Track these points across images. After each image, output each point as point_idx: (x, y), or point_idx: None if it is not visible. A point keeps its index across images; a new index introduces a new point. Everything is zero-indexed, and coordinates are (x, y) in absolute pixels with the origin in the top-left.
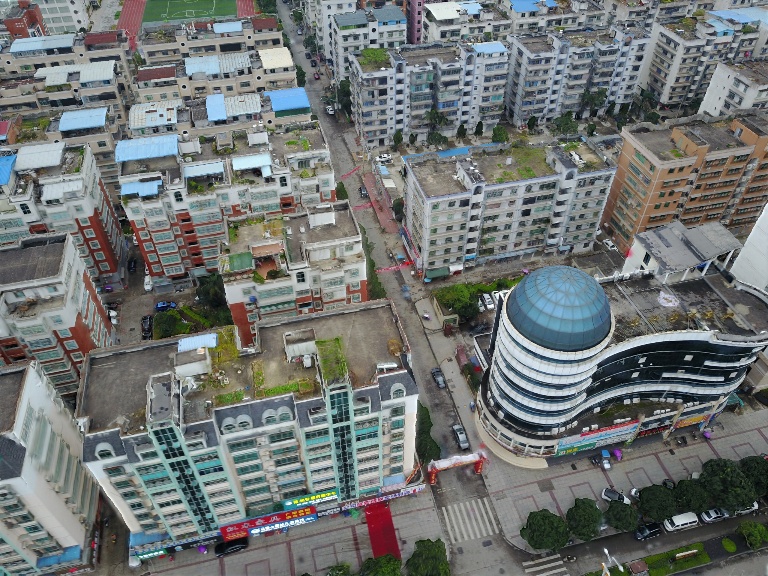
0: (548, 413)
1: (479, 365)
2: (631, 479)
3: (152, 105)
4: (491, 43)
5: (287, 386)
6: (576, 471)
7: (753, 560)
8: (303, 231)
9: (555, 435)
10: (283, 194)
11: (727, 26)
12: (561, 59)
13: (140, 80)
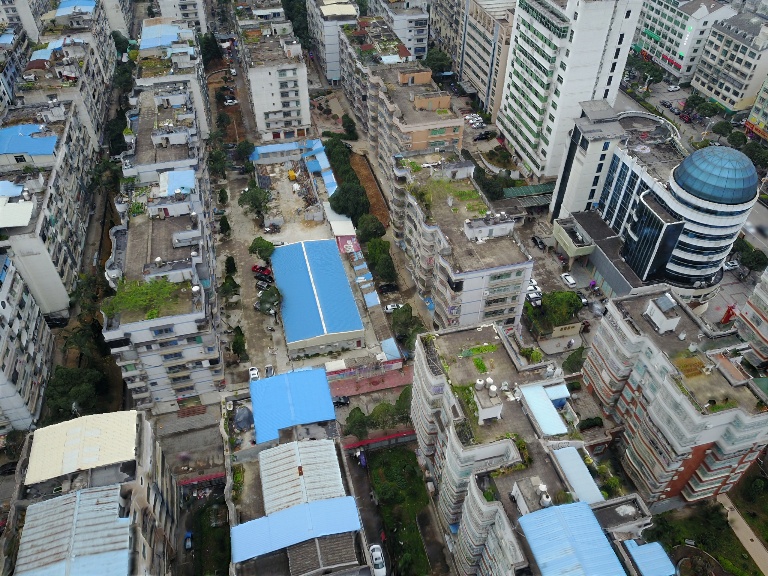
0: None
1: None
2: None
3: None
4: (168, 179)
5: None
6: None
7: None
8: None
9: None
10: None
11: None
12: None
13: None
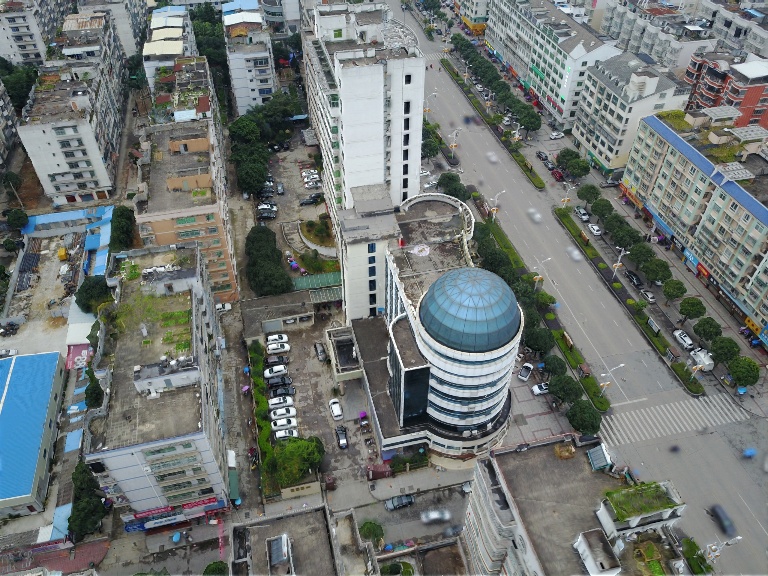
0: None
1: (396, 451)
2: None
3: None
4: None
5: None
6: None
7: (554, 309)
8: None
9: None
10: None
11: None
12: None
13: None
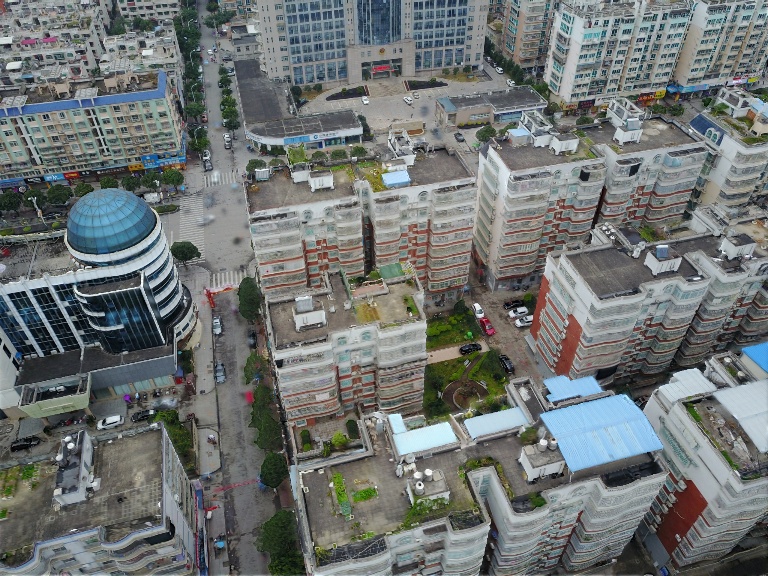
0: None
1: None
2: None
3: None
4: None
5: None
6: None
7: None
8: None
9: None
10: None
11: None
12: None
13: None
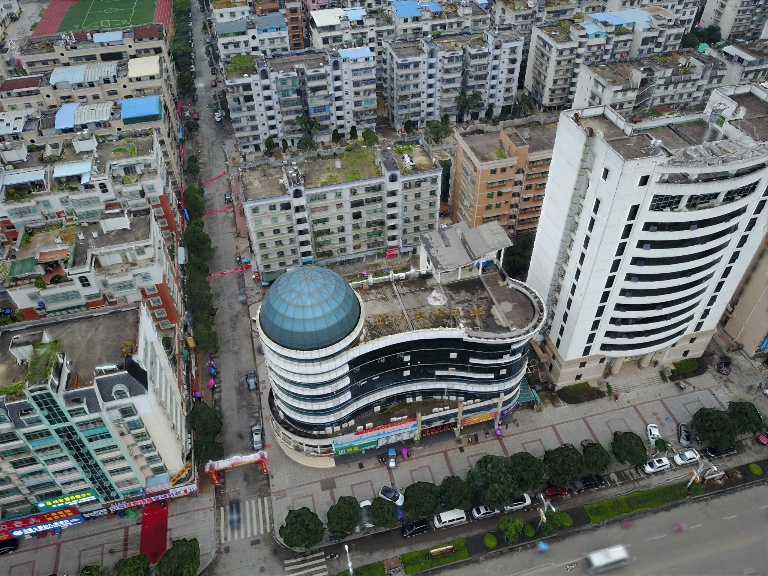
0: (315, 412)
1: None
2: (414, 477)
3: (3, 114)
4: (358, 48)
5: (7, 388)
6: (362, 470)
7: (513, 555)
8: (96, 236)
9: (330, 434)
10: (107, 200)
11: (600, 28)
12: (431, 63)
13: (2, 90)
